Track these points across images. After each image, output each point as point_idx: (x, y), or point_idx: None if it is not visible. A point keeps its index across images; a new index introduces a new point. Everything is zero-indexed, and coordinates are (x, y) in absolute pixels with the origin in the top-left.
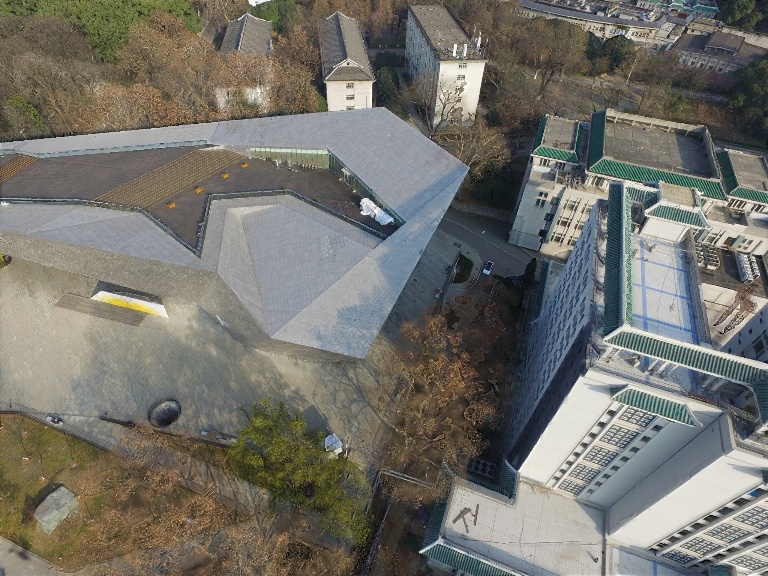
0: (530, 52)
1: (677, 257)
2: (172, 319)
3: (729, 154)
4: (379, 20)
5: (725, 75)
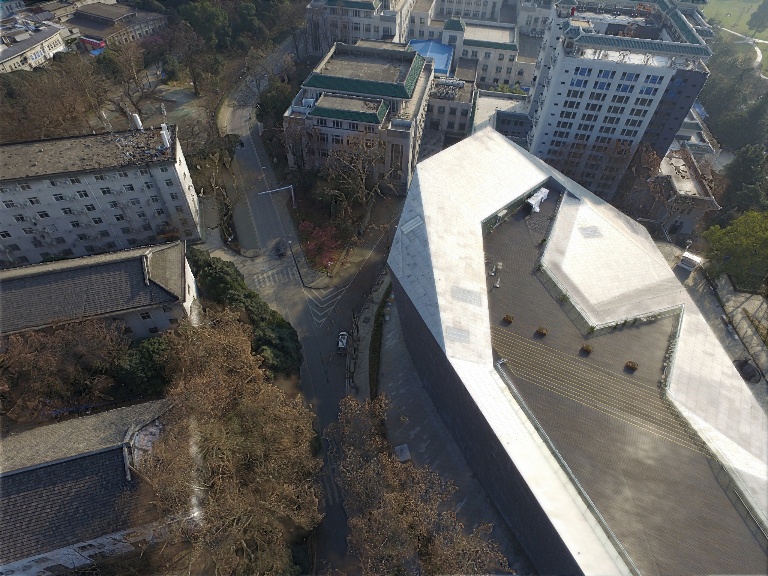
0: None
1: None
2: None
3: None
4: None
5: None
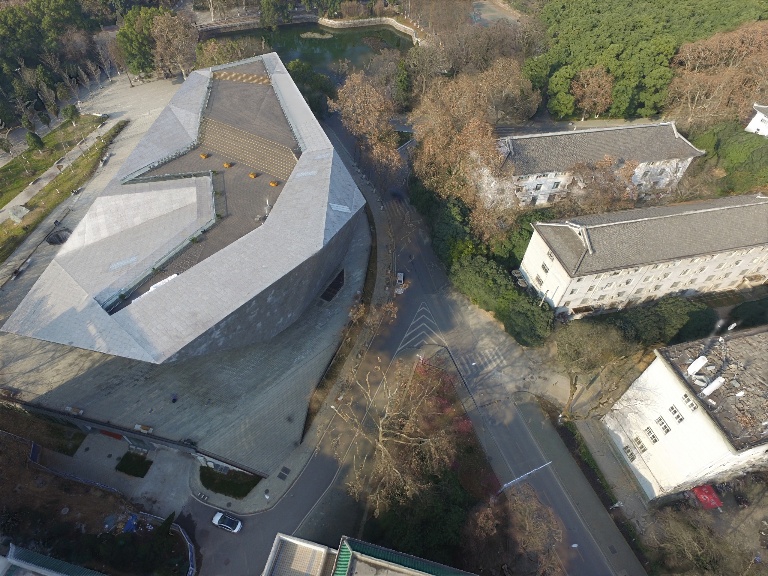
0: None
1: None
2: None
3: None
4: None
5: None
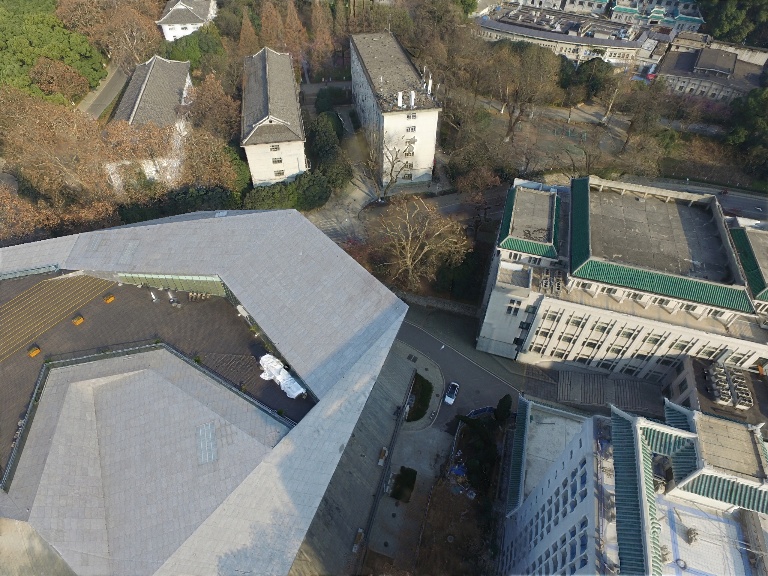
0: (494, 84)
1: (734, 551)
2: (5, 539)
3: (747, 234)
4: (317, 53)
5: (722, 106)
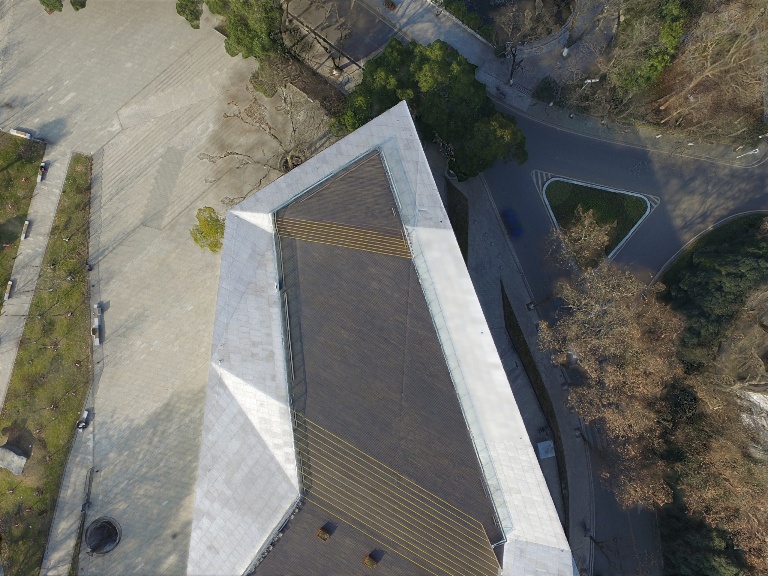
0: None
1: None
2: None
3: None
4: None
5: None
